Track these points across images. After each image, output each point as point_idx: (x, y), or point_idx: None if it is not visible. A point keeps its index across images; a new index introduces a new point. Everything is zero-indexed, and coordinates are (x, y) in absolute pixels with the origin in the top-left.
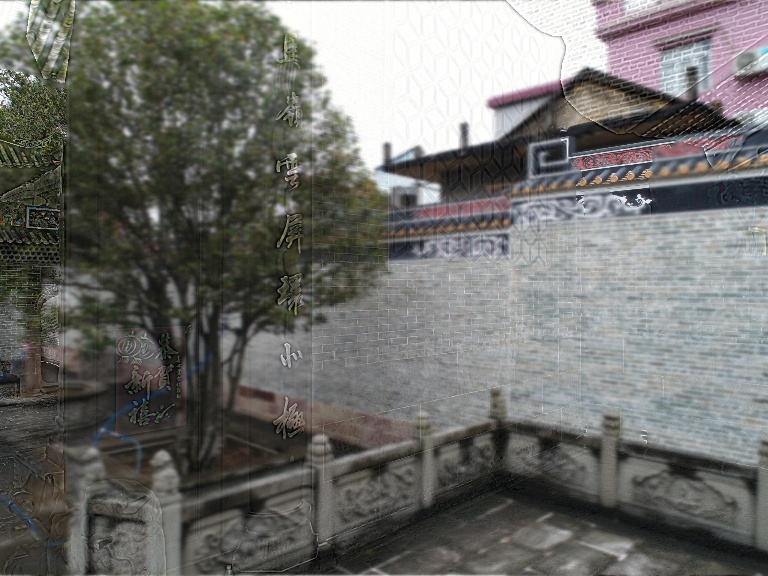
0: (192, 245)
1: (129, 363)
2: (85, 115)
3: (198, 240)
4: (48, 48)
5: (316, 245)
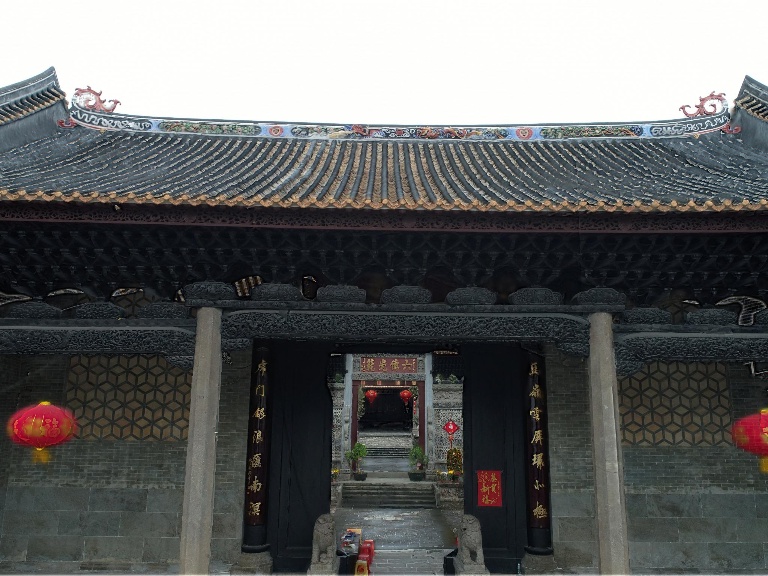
0: (502, 442)
1: (482, 482)
2: (467, 404)
3: (504, 440)
4: None
5: (551, 441)
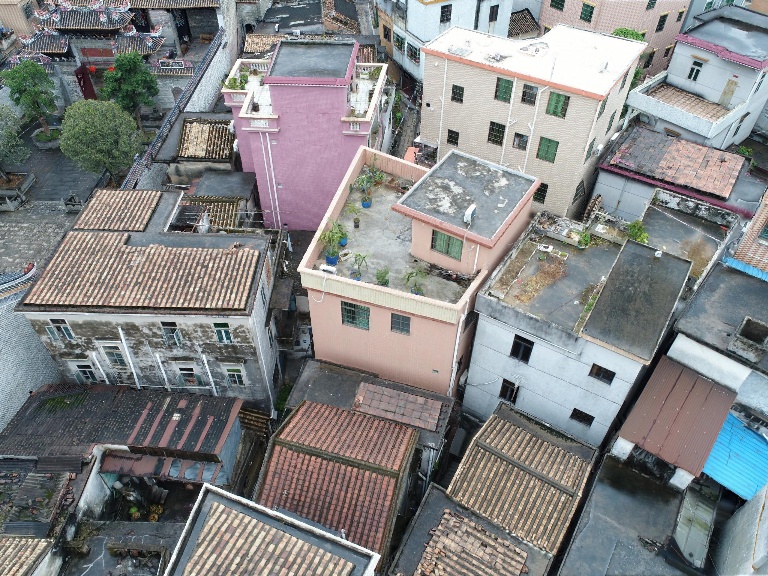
0: None
1: None
2: None
3: None
4: (103, 2)
5: None
